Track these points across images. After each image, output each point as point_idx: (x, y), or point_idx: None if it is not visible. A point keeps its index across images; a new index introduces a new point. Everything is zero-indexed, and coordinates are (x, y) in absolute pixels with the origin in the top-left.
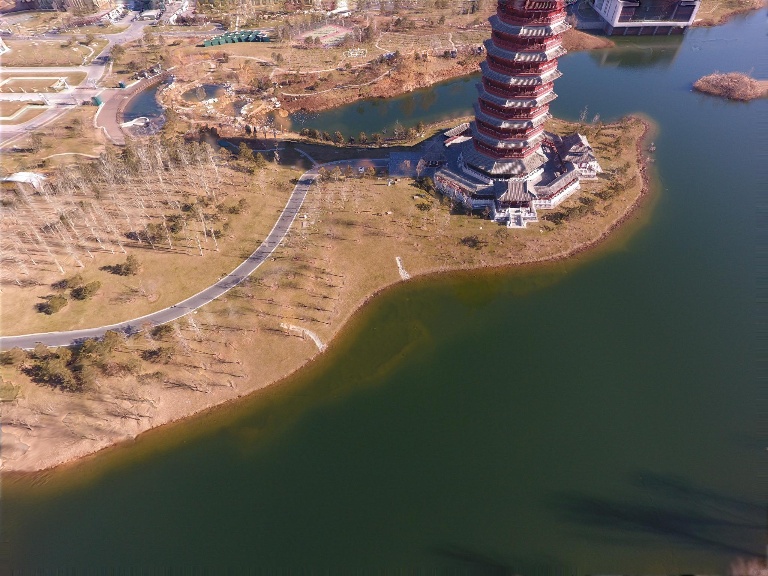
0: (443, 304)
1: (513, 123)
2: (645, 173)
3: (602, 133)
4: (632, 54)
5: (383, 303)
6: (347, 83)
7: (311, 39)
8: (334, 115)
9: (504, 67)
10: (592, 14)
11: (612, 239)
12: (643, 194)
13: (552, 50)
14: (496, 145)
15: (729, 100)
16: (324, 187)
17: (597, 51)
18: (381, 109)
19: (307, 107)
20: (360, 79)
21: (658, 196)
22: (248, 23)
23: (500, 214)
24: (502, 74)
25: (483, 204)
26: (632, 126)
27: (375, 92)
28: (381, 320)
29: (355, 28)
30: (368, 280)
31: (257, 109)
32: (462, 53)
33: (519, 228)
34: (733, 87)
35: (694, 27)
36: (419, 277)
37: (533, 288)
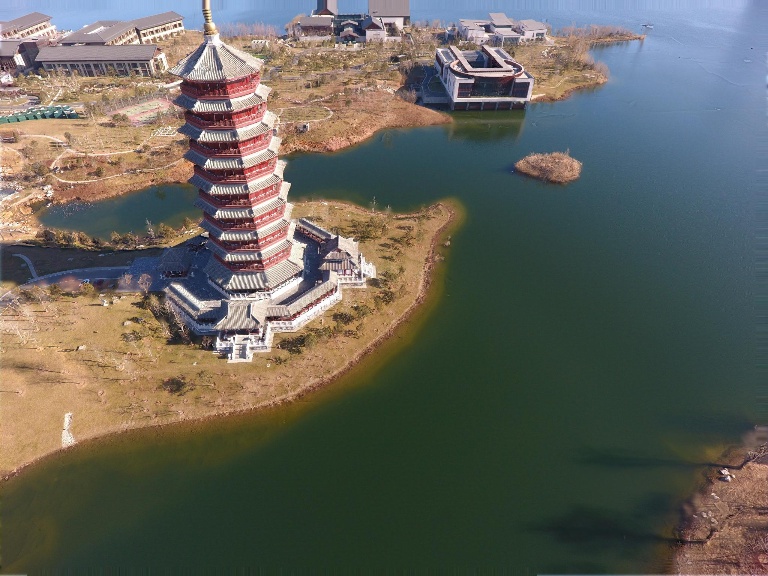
0: (104, 484)
1: (236, 233)
2: (429, 275)
3: (398, 225)
4: (469, 130)
5: (17, 489)
6: (141, 167)
7: (119, 116)
8: (113, 205)
9: (204, 173)
10: (440, 88)
11: (359, 369)
12: (416, 304)
13: (257, 154)
14: (224, 258)
15: (547, 182)
16: (21, 311)
17: (434, 127)
18: (186, 193)
19: (82, 196)
20: (151, 163)
21: (434, 305)
22: (64, 97)
23: (221, 344)
24: (206, 180)
25: (211, 329)
26: (435, 215)
27: (171, 177)
28: (1, 518)
29: (171, 105)
30: (10, 453)
31: (23, 199)
32: (284, 131)
33: (242, 362)
34: (551, 168)
35: (538, 101)
36: (88, 442)
37: (233, 450)
